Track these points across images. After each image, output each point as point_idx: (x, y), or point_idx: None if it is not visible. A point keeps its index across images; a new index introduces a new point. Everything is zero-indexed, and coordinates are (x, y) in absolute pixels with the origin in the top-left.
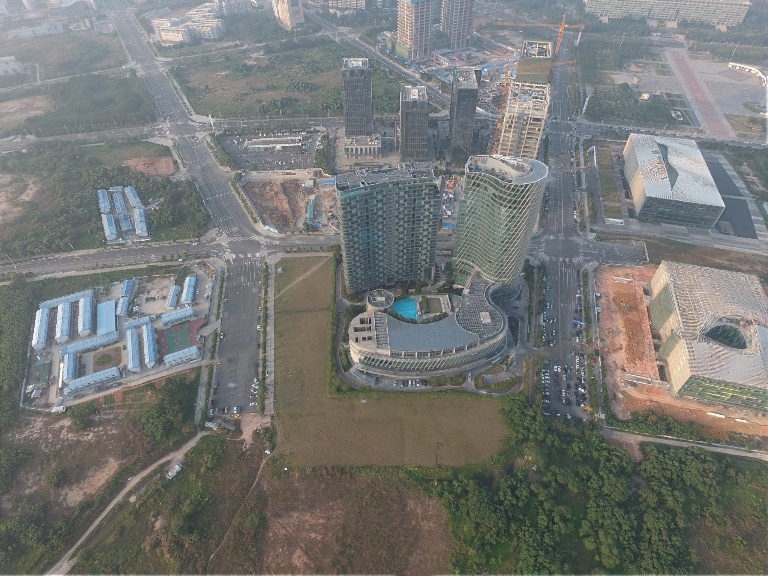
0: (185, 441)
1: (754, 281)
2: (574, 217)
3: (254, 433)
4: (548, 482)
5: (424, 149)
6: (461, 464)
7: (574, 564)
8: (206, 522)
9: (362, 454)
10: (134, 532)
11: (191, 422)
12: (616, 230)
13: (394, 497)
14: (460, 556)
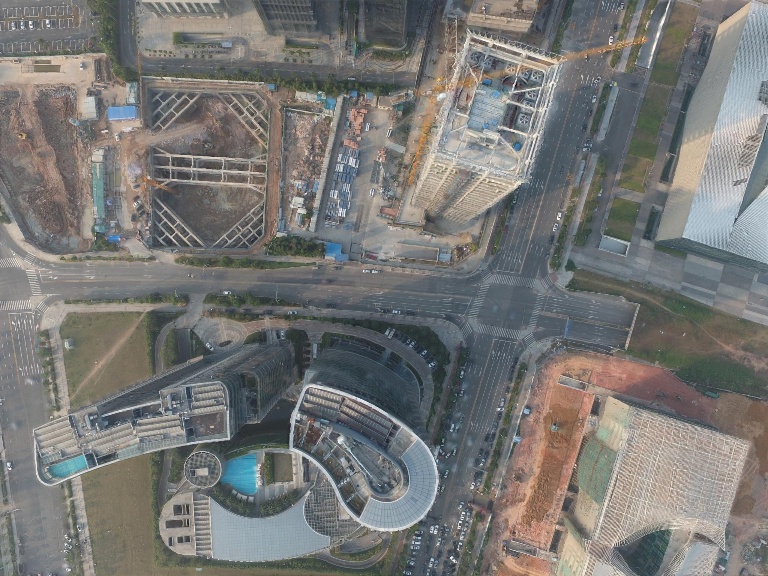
0: None
1: (740, 455)
2: (553, 229)
3: None
4: None
5: (308, 21)
6: None
7: None
8: None
9: None
10: None
11: None
12: (608, 268)
13: None
14: None
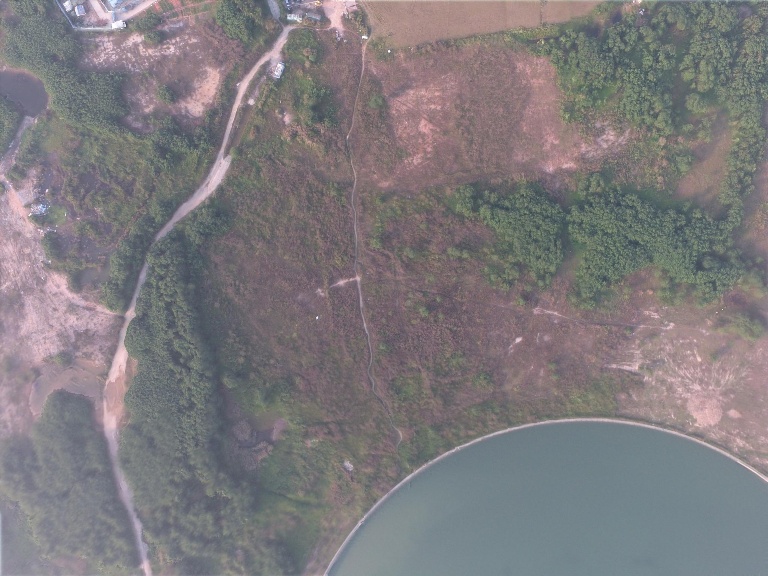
0: (274, 39)
1: None
2: None
3: (343, 19)
4: (657, 23)
5: None
6: (567, 19)
7: (671, 94)
8: (331, 110)
9: (463, 24)
10: (269, 129)
11: (272, 17)
12: None
13: (503, 62)
14: (568, 103)
